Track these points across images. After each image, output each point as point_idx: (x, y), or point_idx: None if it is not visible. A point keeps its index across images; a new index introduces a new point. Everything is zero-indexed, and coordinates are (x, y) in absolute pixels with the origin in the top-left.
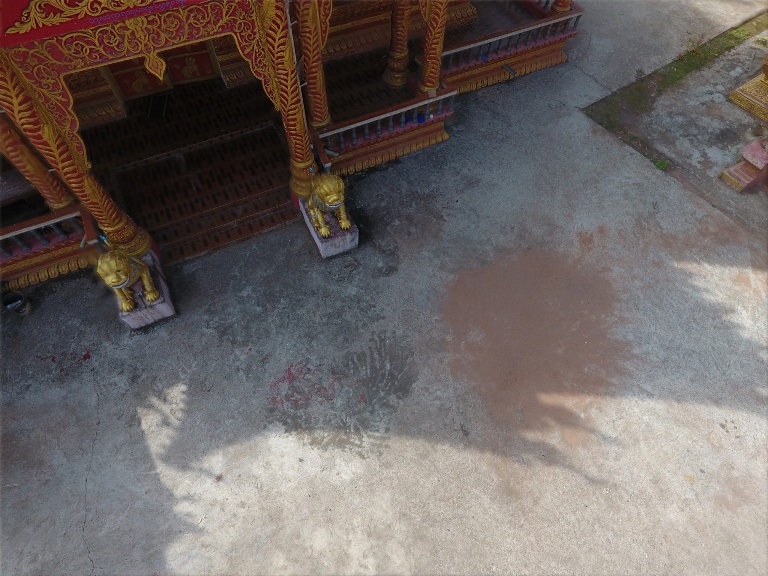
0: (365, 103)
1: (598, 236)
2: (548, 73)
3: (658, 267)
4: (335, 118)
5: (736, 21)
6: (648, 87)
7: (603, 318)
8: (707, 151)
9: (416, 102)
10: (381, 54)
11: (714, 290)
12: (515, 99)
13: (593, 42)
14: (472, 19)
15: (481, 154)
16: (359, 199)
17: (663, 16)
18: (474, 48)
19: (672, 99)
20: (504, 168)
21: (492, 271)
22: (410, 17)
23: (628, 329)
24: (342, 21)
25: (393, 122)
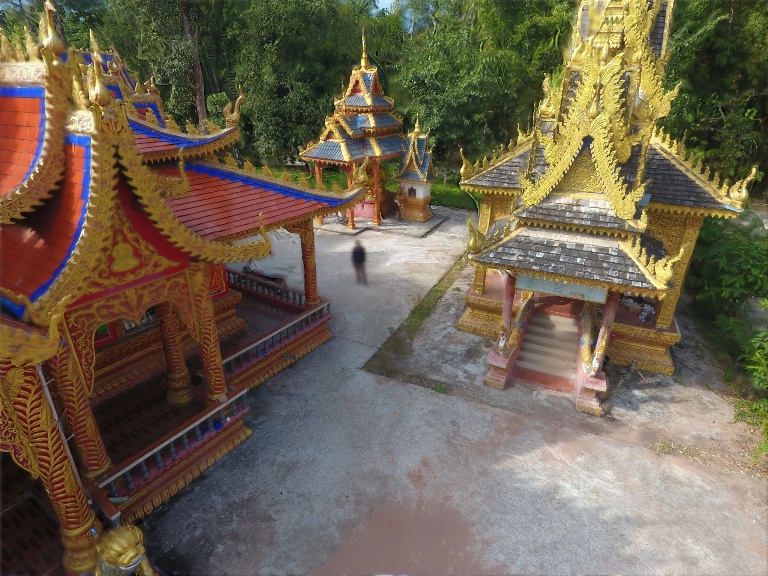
0: (151, 430)
1: (425, 470)
2: (322, 349)
3: (485, 476)
4: (117, 458)
5: (434, 281)
6: (402, 337)
7: (469, 550)
8: (465, 368)
9: (208, 412)
10: (160, 379)
11: (535, 476)
12: (303, 378)
13: (347, 318)
14: (242, 327)
15: (289, 436)
16: (166, 540)
17: (387, 289)
18: (251, 349)
19: (422, 340)
20: (316, 441)
21: (345, 554)
22: (182, 341)
23: (495, 550)
24: (110, 362)
25: (188, 439)
